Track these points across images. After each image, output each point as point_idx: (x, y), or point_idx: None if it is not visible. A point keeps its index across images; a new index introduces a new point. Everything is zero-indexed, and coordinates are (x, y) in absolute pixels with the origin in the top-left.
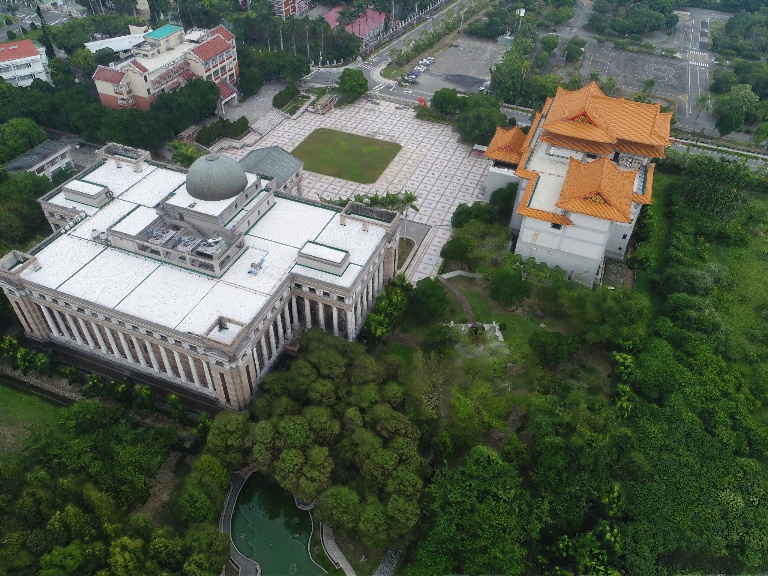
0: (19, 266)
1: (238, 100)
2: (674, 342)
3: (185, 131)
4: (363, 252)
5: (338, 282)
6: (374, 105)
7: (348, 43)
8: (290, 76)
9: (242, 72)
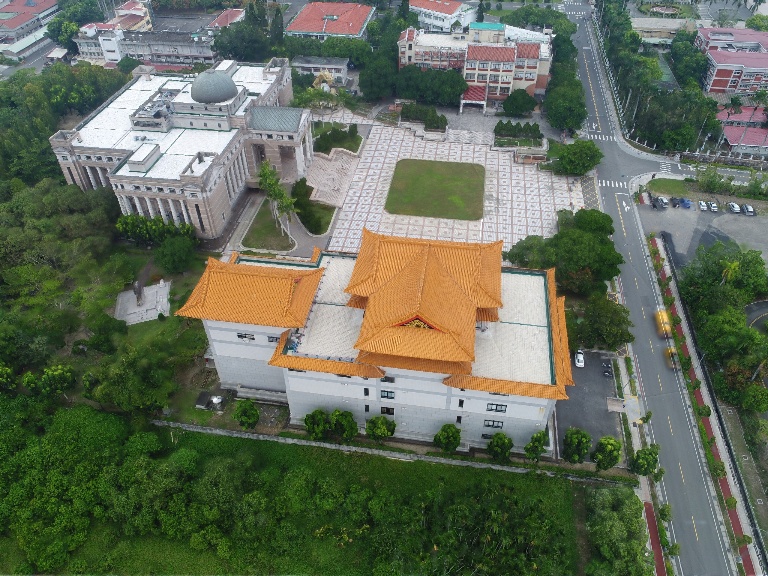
0: None
1: (496, 112)
2: None
3: (402, 100)
4: (161, 176)
5: (123, 171)
6: (566, 189)
7: (664, 129)
8: (552, 119)
9: None
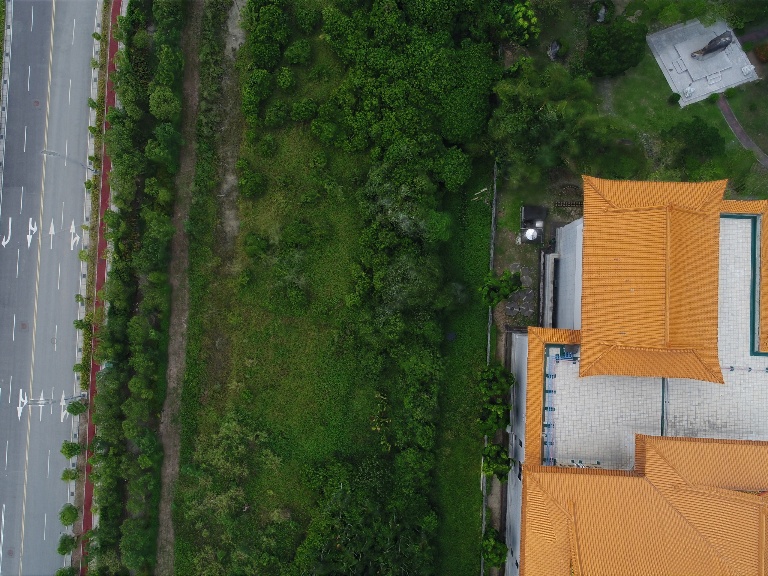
0: None
1: None
2: (442, 140)
3: None
4: None
5: None
6: None
7: None
8: None
9: None
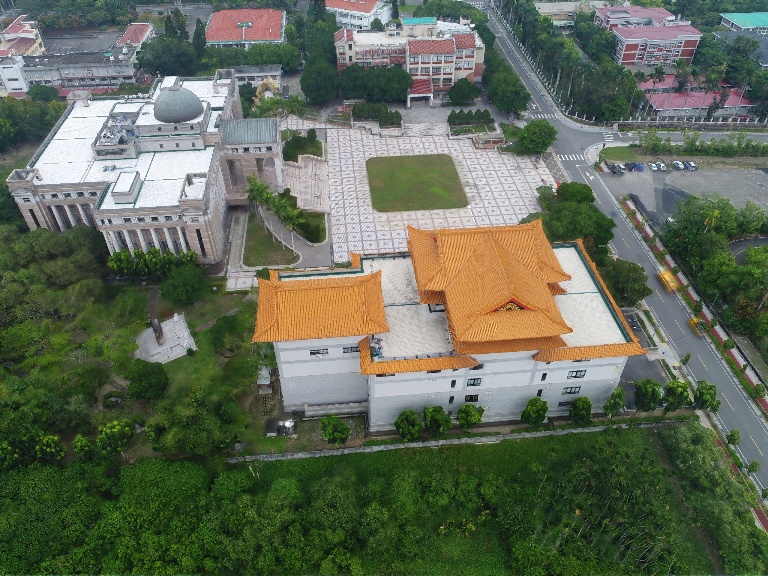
0: (88, 101)
1: (441, 103)
2: None
3: (351, 100)
4: (153, 204)
5: (107, 205)
6: (532, 167)
7: (603, 102)
8: (499, 104)
9: (458, 80)
